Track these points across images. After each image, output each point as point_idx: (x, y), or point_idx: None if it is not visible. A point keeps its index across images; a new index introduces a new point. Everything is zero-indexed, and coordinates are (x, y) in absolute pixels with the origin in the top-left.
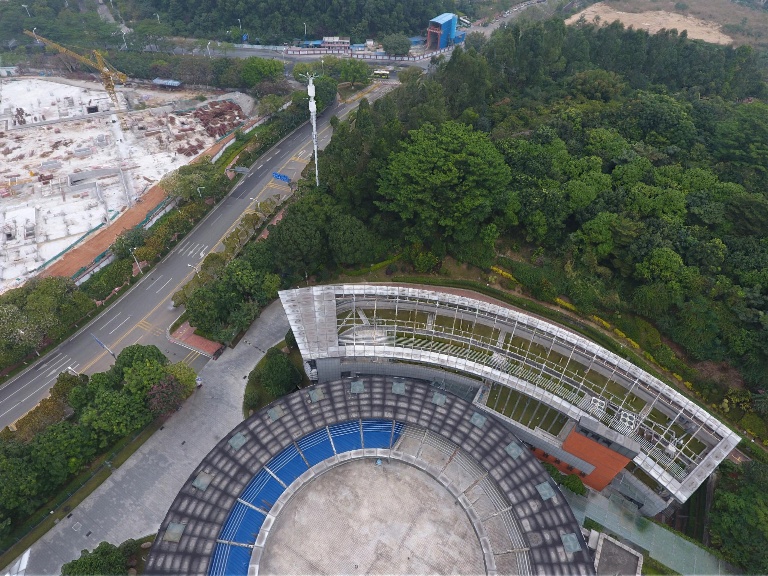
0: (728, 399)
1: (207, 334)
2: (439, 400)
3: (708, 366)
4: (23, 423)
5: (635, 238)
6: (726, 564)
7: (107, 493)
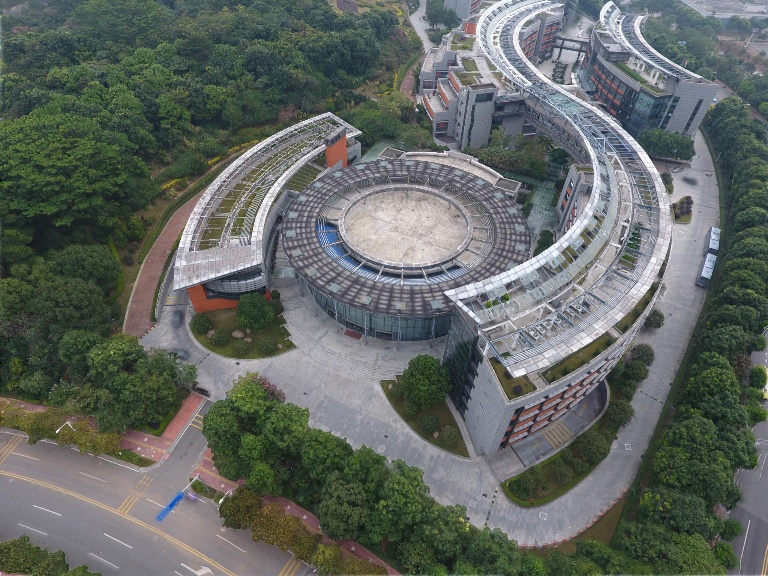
0: (300, 119)
1: (170, 413)
2: (304, 199)
3: (283, 114)
4: (288, 532)
5: (188, 96)
6: (380, 142)
7: (352, 438)
